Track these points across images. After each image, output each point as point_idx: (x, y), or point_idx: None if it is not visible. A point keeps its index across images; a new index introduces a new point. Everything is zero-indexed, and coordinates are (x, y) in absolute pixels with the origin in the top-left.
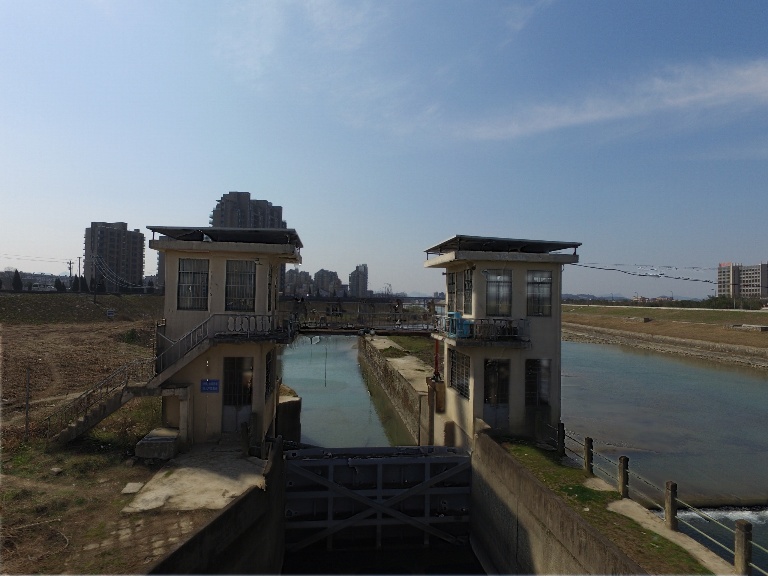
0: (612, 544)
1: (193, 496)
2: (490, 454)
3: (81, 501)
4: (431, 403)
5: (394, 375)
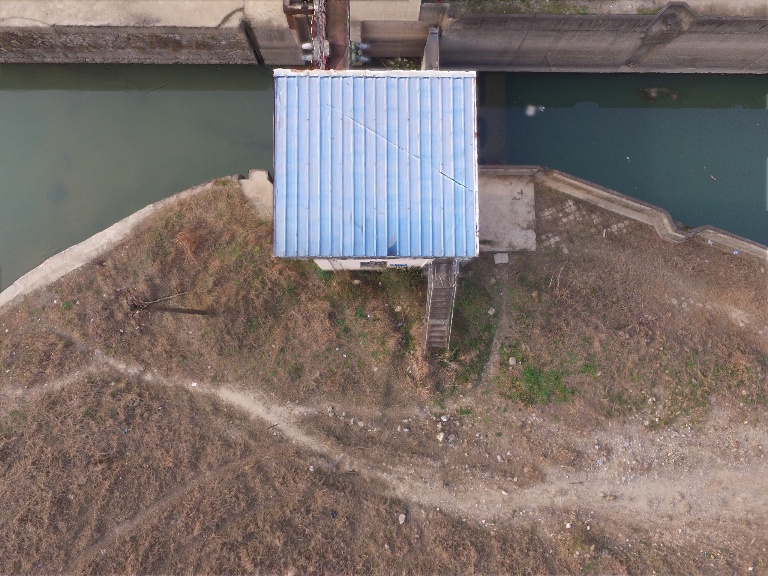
0: (620, 16)
1: (520, 216)
2: (485, 23)
3: (521, 279)
4: (296, 25)
5: (42, 34)
